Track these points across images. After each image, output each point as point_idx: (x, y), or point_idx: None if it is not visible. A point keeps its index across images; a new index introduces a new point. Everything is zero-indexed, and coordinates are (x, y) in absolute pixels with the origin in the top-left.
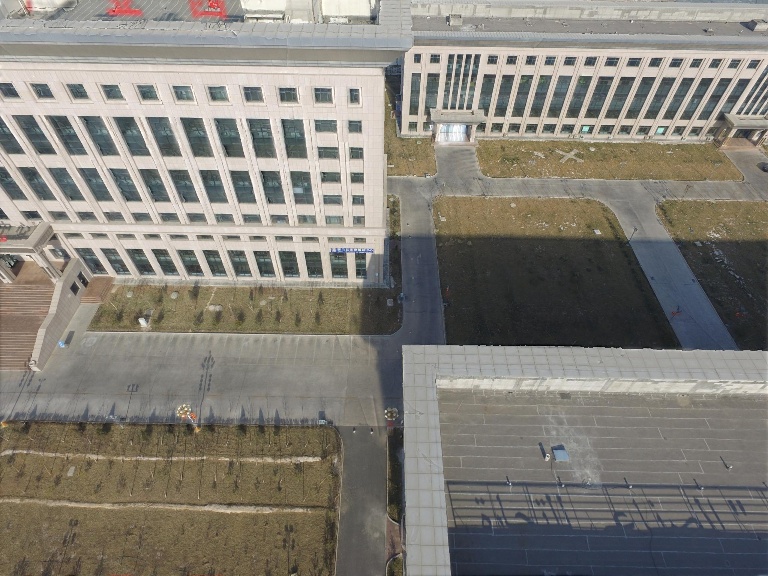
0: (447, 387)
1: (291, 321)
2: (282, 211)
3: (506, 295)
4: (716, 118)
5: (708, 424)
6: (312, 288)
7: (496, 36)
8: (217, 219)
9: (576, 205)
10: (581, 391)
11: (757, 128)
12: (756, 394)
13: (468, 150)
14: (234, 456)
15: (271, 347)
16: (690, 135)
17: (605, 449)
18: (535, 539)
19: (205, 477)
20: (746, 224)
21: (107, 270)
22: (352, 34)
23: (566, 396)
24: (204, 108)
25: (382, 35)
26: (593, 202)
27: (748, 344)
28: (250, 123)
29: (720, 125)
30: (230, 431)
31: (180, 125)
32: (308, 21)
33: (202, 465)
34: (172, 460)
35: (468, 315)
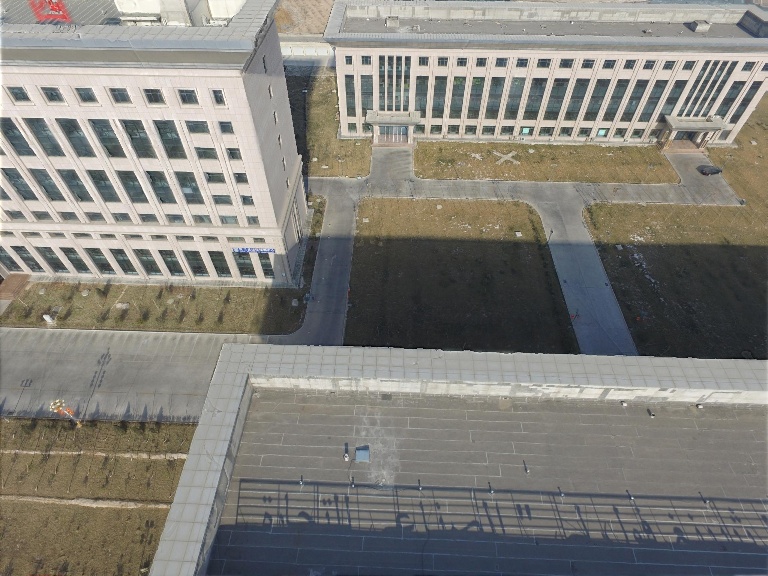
0: (268, 386)
1: (194, 320)
2: (176, 211)
3: (413, 296)
4: (657, 120)
5: (522, 428)
6: (221, 287)
7: (423, 38)
8: (116, 218)
9: (503, 207)
10: (402, 392)
11: (697, 130)
12: (578, 398)
13: (405, 151)
14: (110, 451)
15: (169, 345)
16: (633, 137)
17: (409, 450)
18: (311, 538)
19: (78, 471)
20: (673, 227)
21: (22, 267)
22: (194, 36)
23: (387, 397)
24: (76, 109)
25: (223, 37)
26: (521, 204)
27: (649, 349)
28: (125, 124)
29: (662, 127)
30: (112, 427)
31: (57, 126)
32: (185, 23)
33: (78, 460)
34: (50, 454)
35: (371, 316)
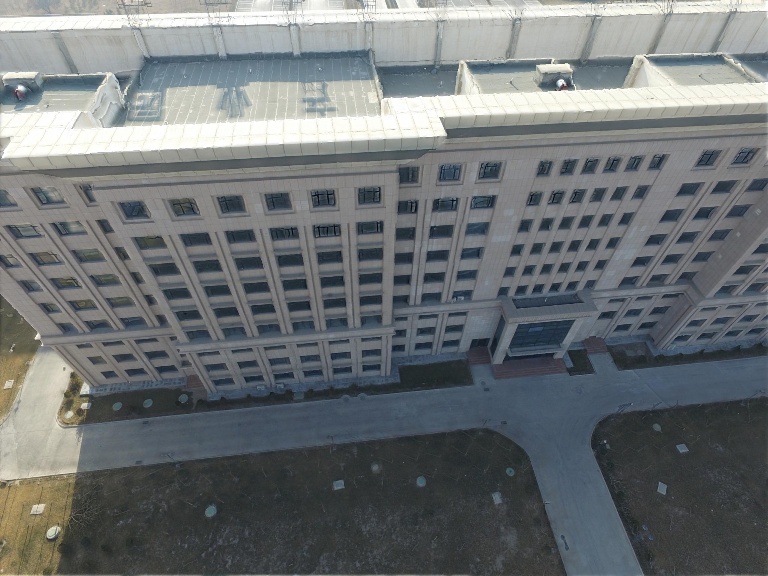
0: None
1: None
2: None
3: None
4: None
5: None
6: None
7: None
8: None
9: None
10: None
11: None
12: None
13: None
14: None
15: None
16: None
17: None
18: None
19: None
20: None
21: None
22: (4, 21)
23: None
24: None
25: None
26: None
27: None
28: None
29: None
30: None
31: None
32: None
33: None
34: None
35: None
